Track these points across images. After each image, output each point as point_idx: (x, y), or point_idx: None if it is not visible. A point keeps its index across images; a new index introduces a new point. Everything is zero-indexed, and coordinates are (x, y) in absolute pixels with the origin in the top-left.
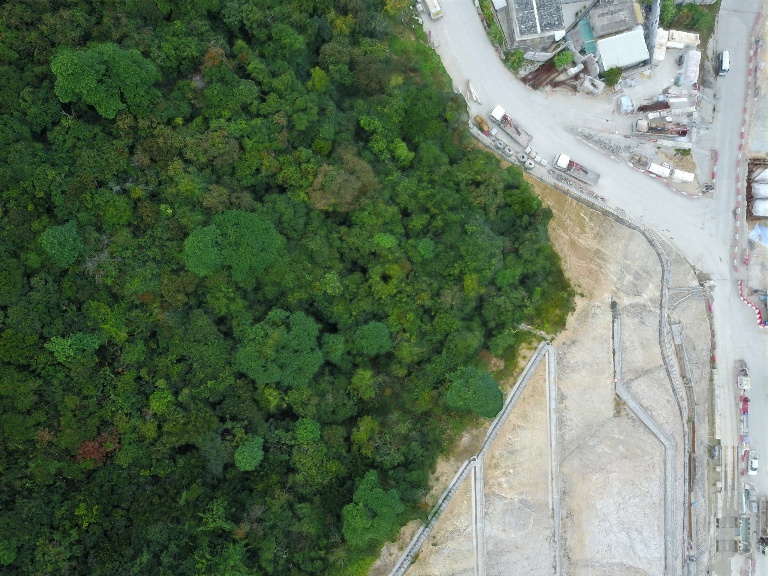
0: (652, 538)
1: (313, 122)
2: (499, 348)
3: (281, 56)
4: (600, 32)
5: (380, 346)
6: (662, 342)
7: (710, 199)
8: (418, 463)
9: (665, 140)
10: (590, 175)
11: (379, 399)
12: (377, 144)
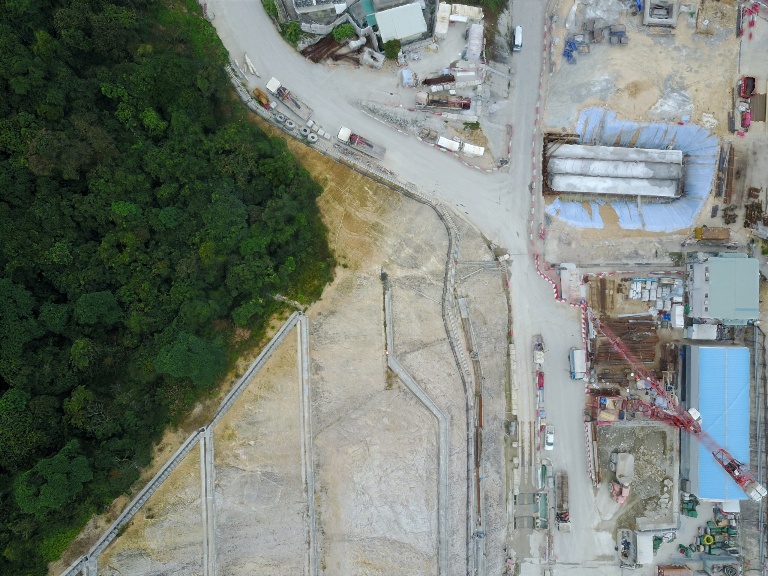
0: (419, 512)
1: (39, 87)
2: (241, 317)
3: (7, 20)
4: (379, 5)
5: (103, 315)
6: (446, 315)
7: (506, 174)
8: (131, 433)
9: (449, 113)
10: (376, 149)
11: (97, 368)
12: (123, 112)
